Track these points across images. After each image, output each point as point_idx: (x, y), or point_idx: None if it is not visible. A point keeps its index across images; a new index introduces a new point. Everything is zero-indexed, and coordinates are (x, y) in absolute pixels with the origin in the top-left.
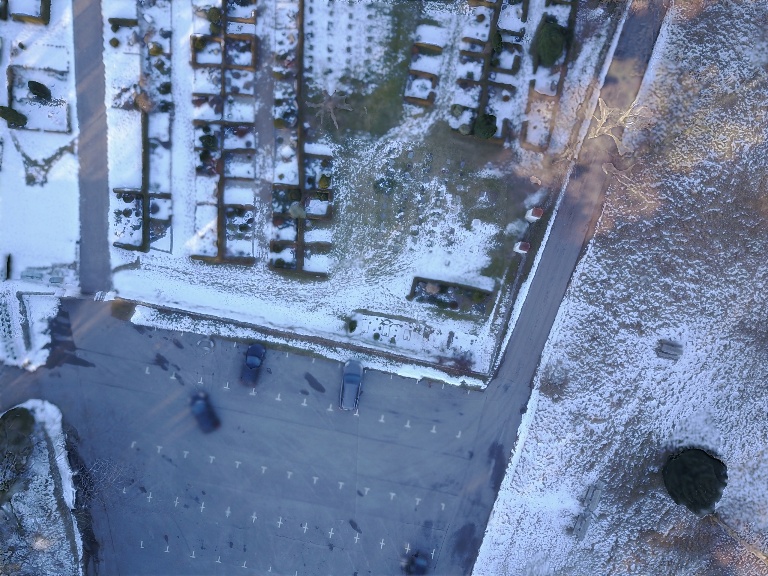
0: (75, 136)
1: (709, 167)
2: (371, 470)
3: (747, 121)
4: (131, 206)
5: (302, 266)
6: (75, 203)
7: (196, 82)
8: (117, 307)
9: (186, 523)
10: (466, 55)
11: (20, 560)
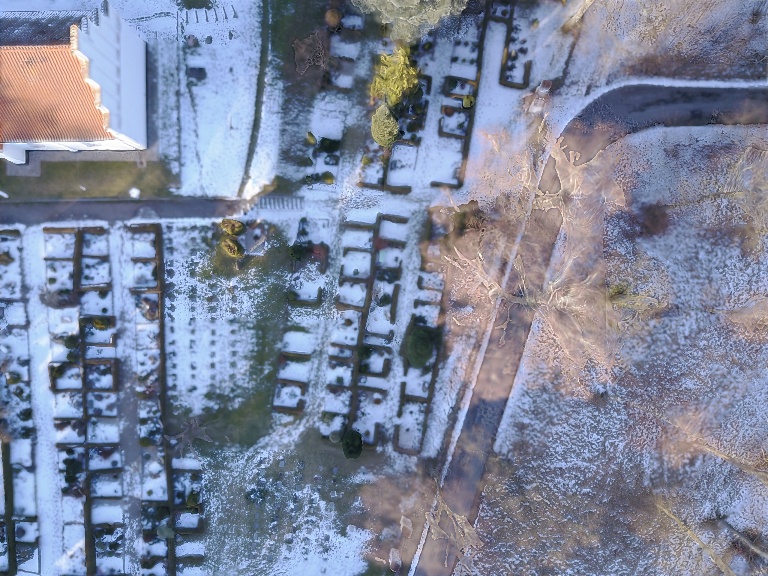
0: None
1: (583, 468)
2: None
3: (620, 420)
4: None
5: None
6: None
7: (57, 406)
8: None
9: None
10: (335, 360)
11: None
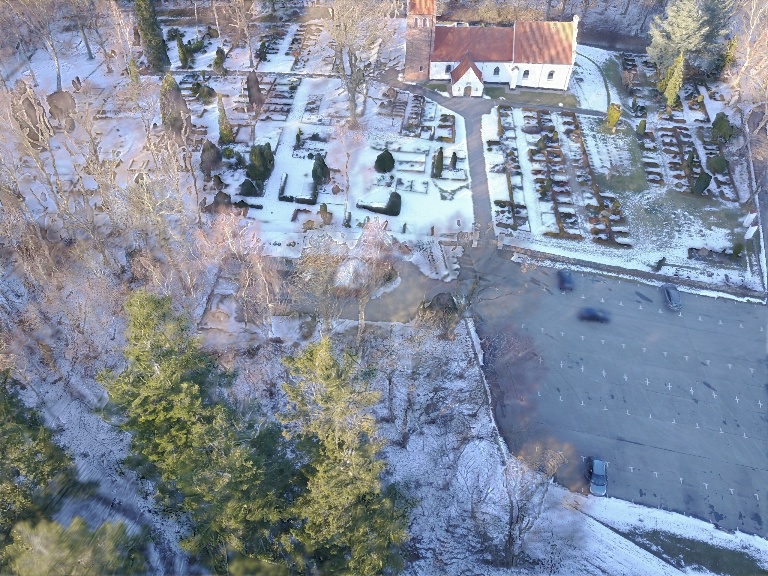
0: (469, 182)
1: None
2: (706, 349)
3: None
4: (505, 209)
5: (615, 240)
6: (471, 207)
7: (533, 166)
8: (501, 253)
9: (572, 380)
10: (673, 168)
11: (440, 401)
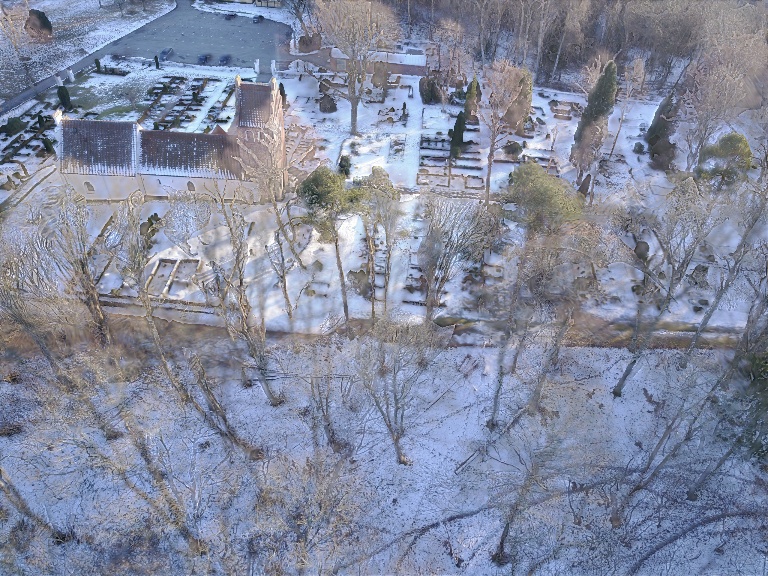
0: None
1: None
2: (169, 43)
3: None
4: None
5: None
6: None
7: None
8: None
9: None
10: None
11: None
